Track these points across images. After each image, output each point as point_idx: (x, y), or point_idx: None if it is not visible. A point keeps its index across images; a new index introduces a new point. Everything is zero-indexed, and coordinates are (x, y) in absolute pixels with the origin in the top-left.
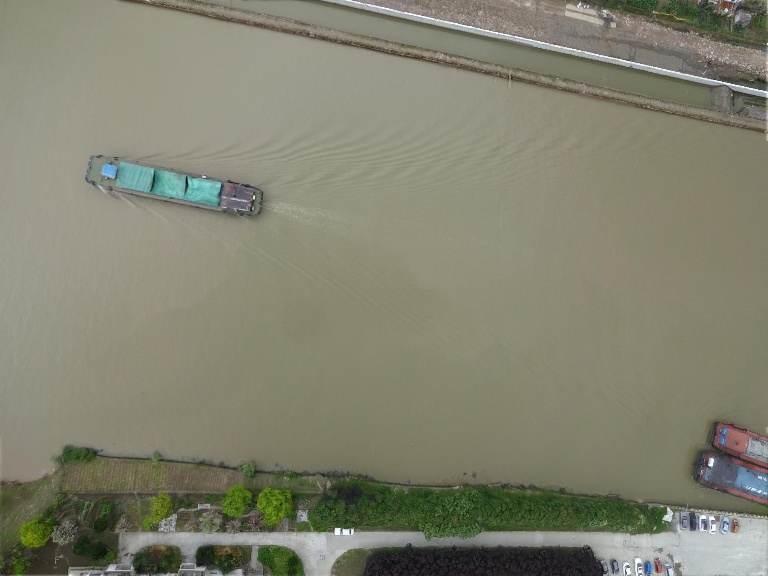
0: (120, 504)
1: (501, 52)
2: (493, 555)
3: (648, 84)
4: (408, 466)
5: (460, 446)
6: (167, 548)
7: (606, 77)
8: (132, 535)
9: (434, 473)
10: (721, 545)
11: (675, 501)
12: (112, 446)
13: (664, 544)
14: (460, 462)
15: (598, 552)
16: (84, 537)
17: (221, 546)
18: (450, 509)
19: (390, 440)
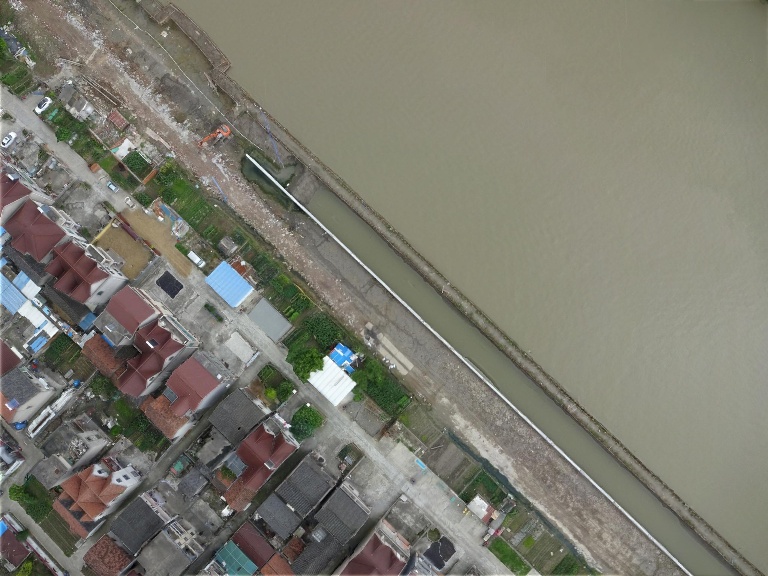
0: None
1: (500, 374)
2: None
3: (369, 250)
4: None
5: None
6: None
7: (407, 284)
8: None
9: None
10: None
11: None
12: None
13: None
14: None
15: None
16: None
17: None
18: None
19: None
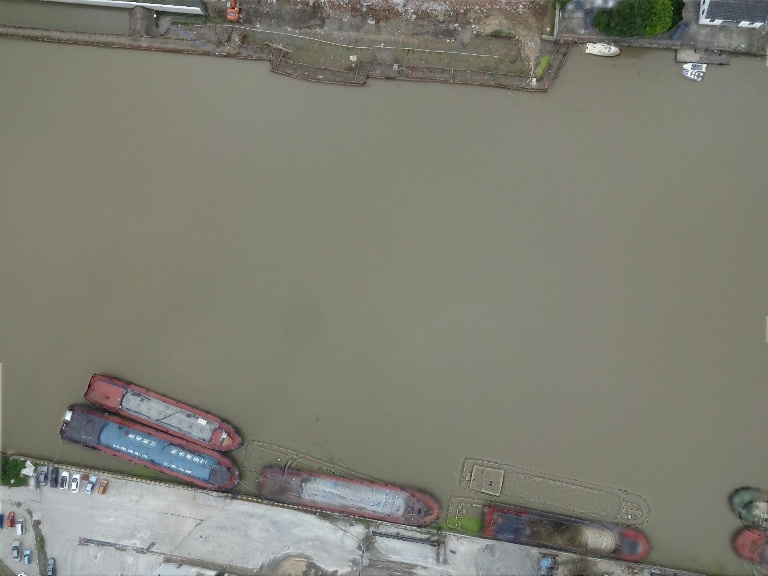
0: None
1: None
2: None
3: (58, 15)
4: None
5: None
6: None
7: (12, 13)
8: None
9: None
10: (89, 506)
11: (46, 455)
12: None
13: (23, 499)
14: None
15: None
16: None
17: None
18: None
19: None
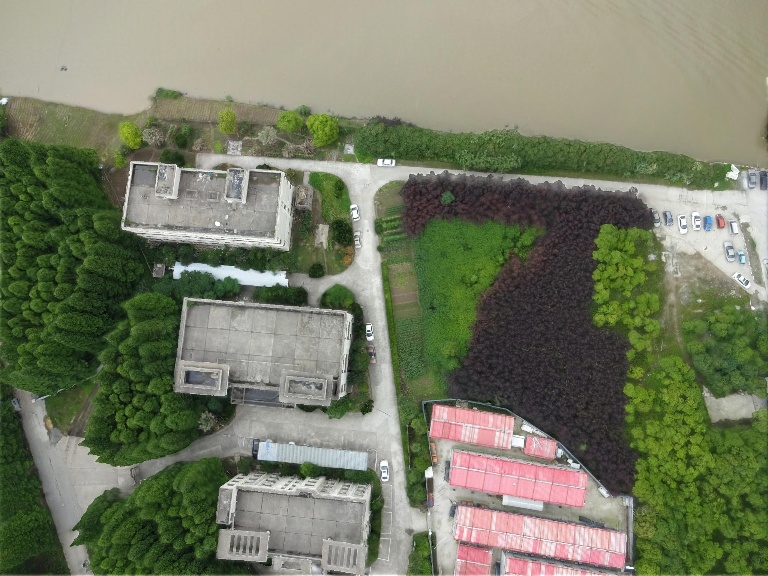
0: (197, 129)
1: None
2: (530, 186)
3: None
4: (450, 118)
5: (502, 100)
6: (233, 165)
7: None
8: (206, 156)
9: (475, 124)
10: None
11: (743, 163)
12: (194, 91)
13: (728, 202)
14: (502, 115)
15: (649, 204)
16: (168, 150)
17: (278, 168)
18: (486, 138)
19: (433, 92)
